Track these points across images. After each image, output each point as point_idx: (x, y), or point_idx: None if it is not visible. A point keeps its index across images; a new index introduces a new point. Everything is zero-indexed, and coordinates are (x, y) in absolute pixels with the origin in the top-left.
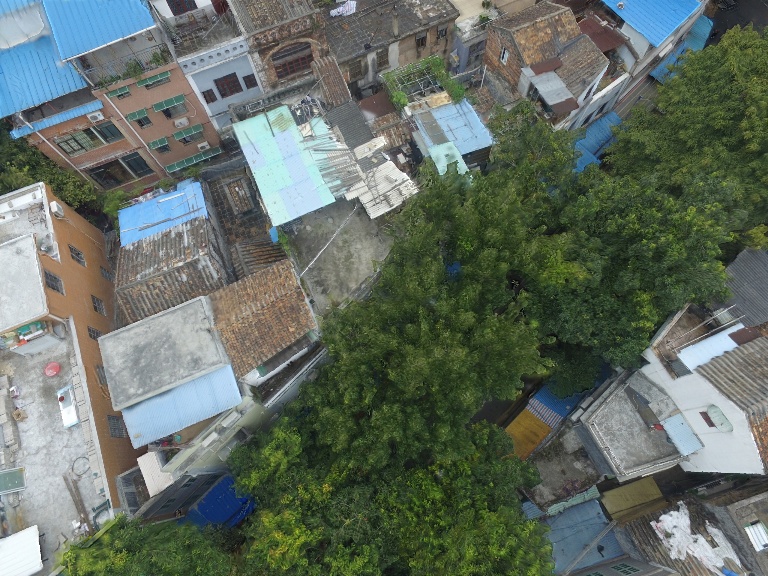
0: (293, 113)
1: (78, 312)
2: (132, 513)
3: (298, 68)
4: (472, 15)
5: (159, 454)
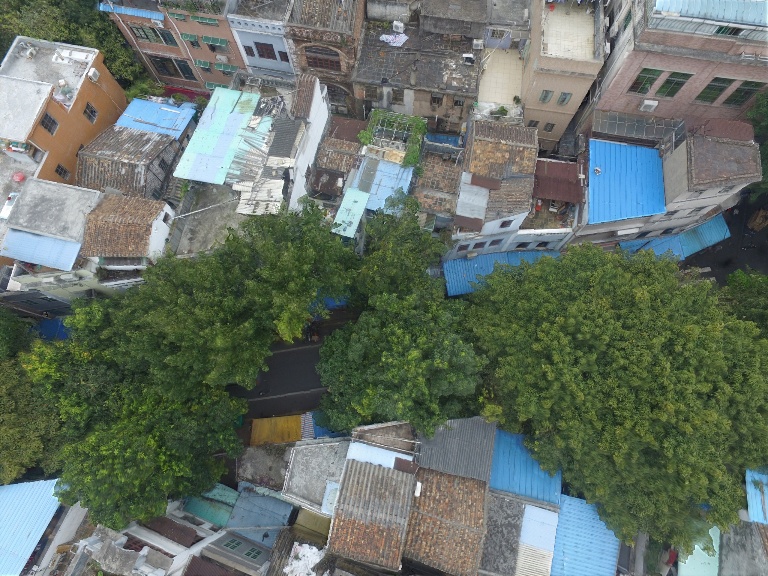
0: (259, 104)
1: (57, 151)
2: None
3: (327, 66)
4: (500, 102)
5: (18, 268)
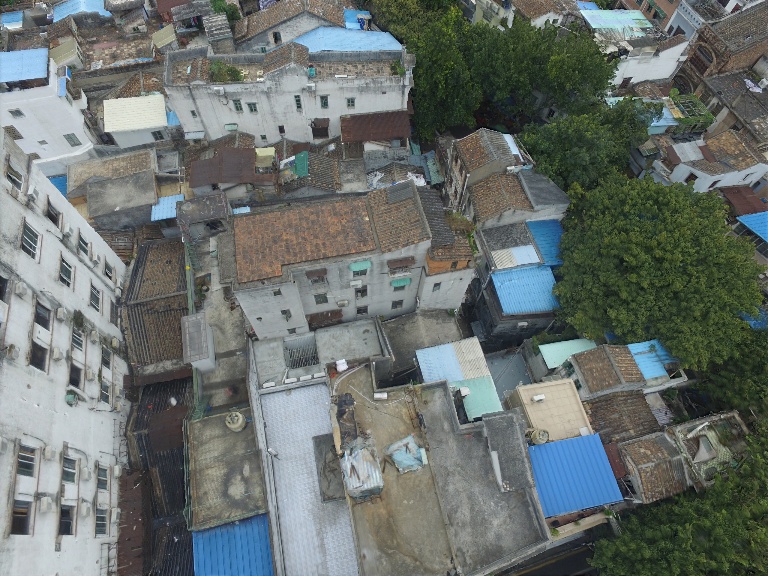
0: (648, 28)
1: None
2: (463, 0)
3: (699, 67)
4: None
5: None
